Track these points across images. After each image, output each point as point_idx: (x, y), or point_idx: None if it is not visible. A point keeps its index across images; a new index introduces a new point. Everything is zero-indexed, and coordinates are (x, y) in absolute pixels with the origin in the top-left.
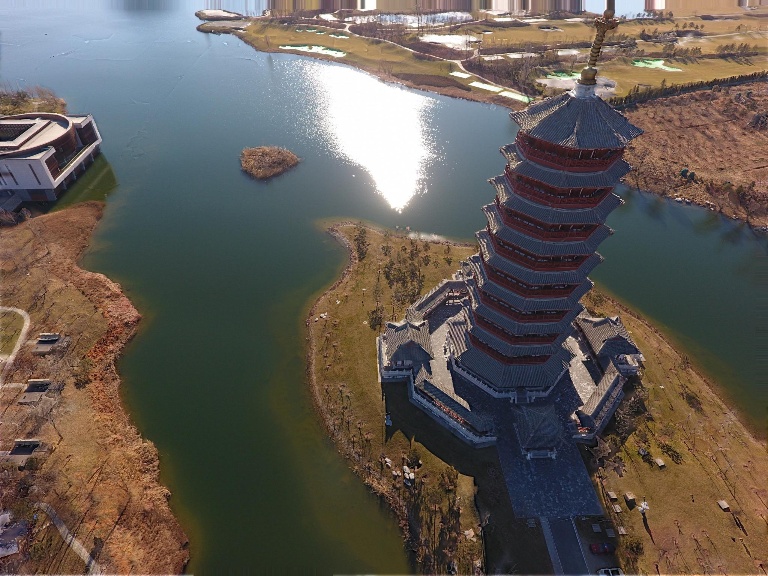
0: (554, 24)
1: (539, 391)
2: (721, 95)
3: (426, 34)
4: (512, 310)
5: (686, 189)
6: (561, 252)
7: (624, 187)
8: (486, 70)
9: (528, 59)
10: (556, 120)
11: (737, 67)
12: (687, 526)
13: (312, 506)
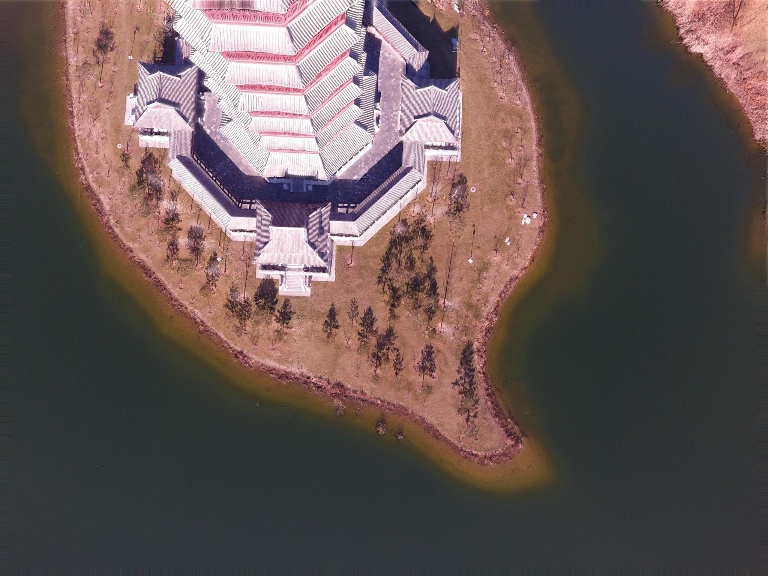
0: None
1: None
2: None
3: None
4: None
5: None
6: None
7: None
8: None
9: None
10: None
11: None
12: None
13: None
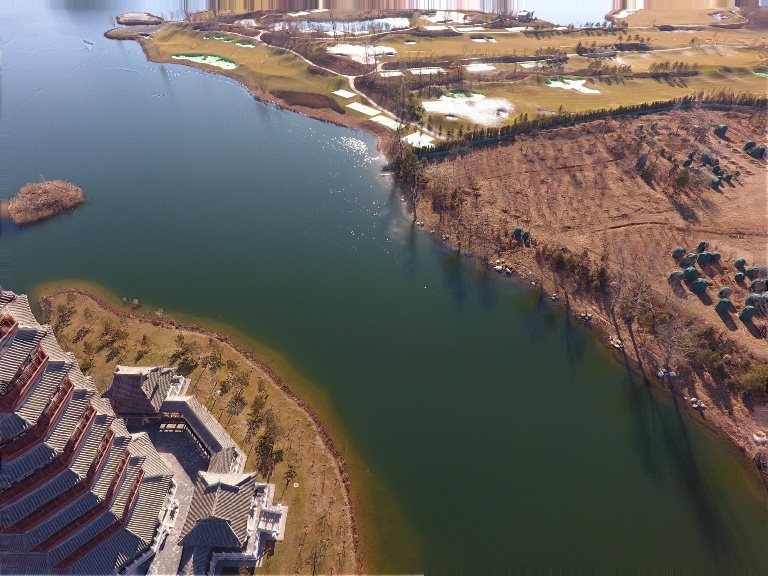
0: (489, 34)
1: None
2: (617, 127)
3: (340, 44)
4: None
5: (512, 254)
6: None
7: (443, 247)
8: (376, 88)
9: (403, 80)
10: None
11: (666, 89)
12: None
13: None
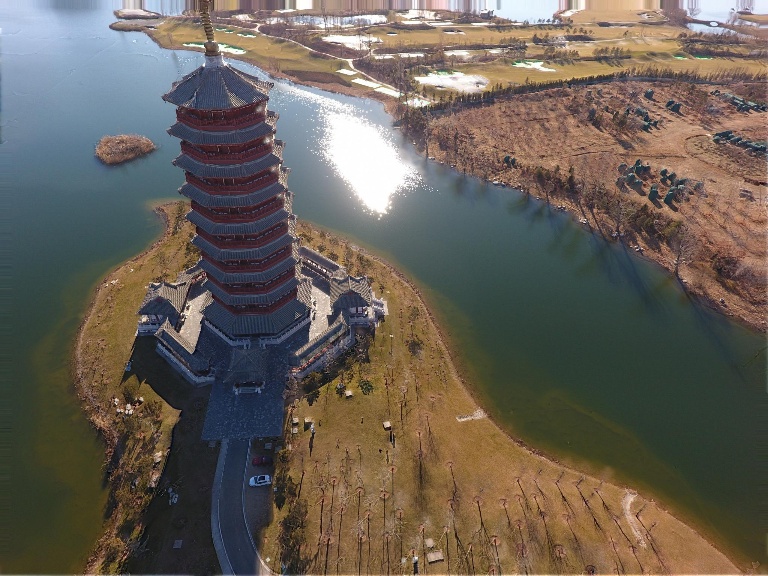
0: (458, 28)
1: (270, 339)
2: (572, 92)
3: (331, 35)
4: (221, 262)
5: (505, 173)
6: (227, 204)
7: (453, 172)
8: (373, 68)
9: (400, 57)
10: (190, 86)
11: (607, 68)
12: (346, 442)
13: (35, 440)
